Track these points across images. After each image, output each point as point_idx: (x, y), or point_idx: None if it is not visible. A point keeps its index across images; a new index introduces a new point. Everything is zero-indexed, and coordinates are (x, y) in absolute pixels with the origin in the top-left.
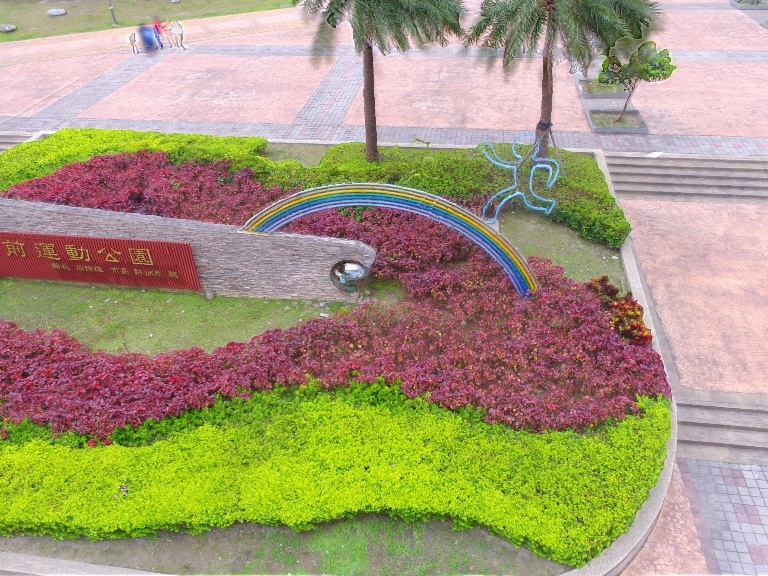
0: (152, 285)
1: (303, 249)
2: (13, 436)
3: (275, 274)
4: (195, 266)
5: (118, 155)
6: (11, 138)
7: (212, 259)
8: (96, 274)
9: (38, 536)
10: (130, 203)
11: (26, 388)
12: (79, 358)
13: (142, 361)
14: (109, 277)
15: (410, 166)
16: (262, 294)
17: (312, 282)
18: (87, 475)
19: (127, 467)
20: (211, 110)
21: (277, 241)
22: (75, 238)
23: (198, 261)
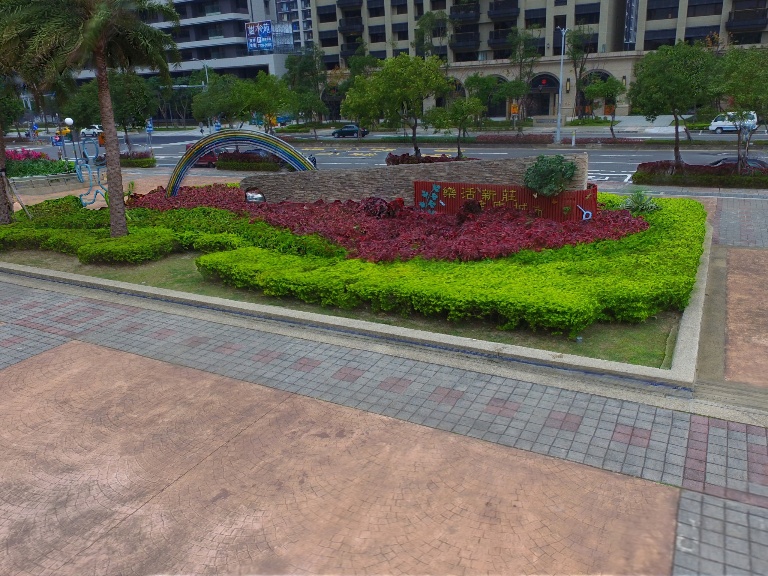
0: None
1: None
2: None
3: None
4: None
5: None
6: None
7: None
8: None
9: None
10: None
11: None
12: None
13: None
14: None
15: None
16: None
17: None
18: None
19: None
20: (181, 422)
21: None
22: None
23: None
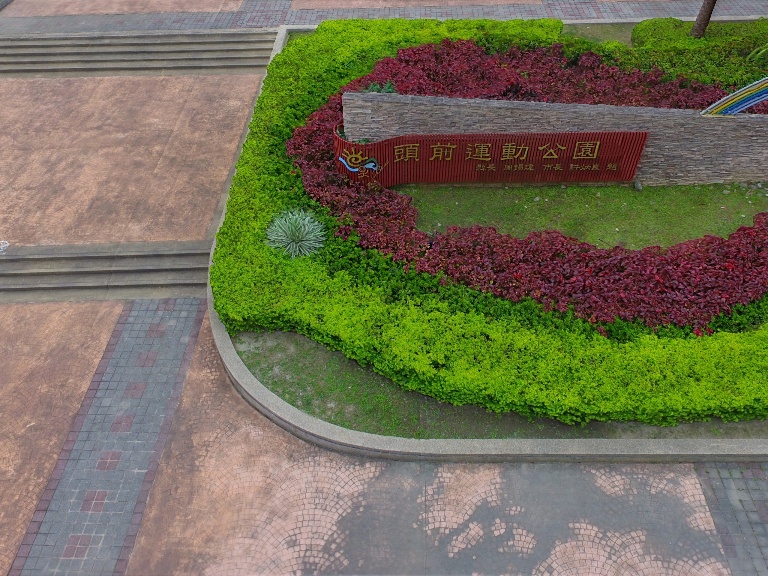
0: (580, 180)
1: (767, 129)
2: (617, 334)
3: (720, 158)
4: (640, 156)
5: (425, 46)
6: (243, 36)
7: (659, 147)
8: (522, 173)
9: (707, 421)
10: (510, 96)
11: (590, 288)
12: (606, 256)
13: (675, 252)
14: (536, 175)
15: (750, 39)
16: (693, 180)
17: (756, 163)
18: (731, 361)
19: (763, 350)
20: None
21: (743, 122)
22: (519, 135)
23: (642, 150)
